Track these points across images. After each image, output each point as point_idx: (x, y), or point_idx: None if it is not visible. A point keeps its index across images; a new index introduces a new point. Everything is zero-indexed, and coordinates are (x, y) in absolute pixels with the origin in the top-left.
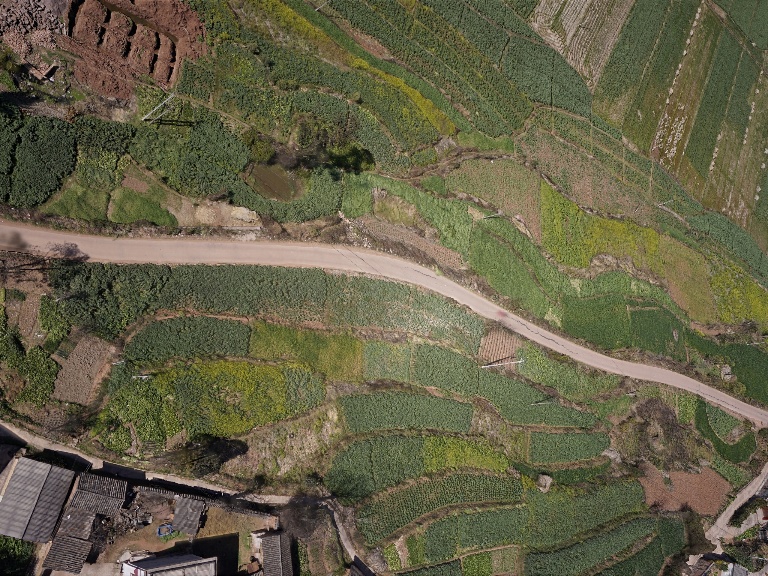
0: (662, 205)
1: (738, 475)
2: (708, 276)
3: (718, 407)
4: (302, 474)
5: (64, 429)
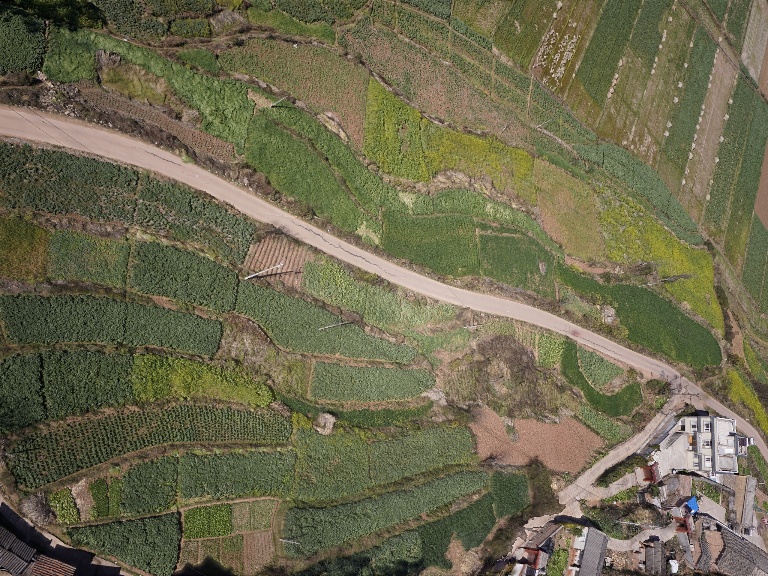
0: (542, 128)
1: (614, 429)
2: (597, 210)
3: (593, 352)
4: None
5: None
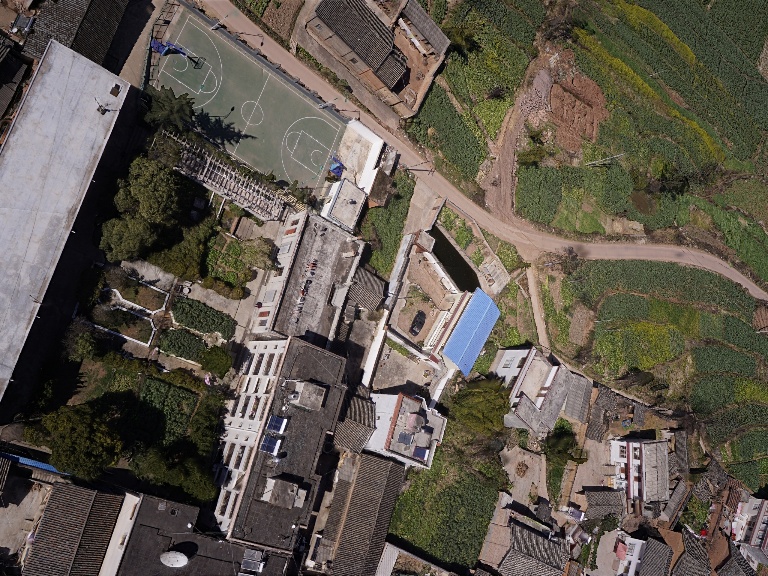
0: None
1: None
2: None
3: None
4: (677, 396)
5: (576, 360)
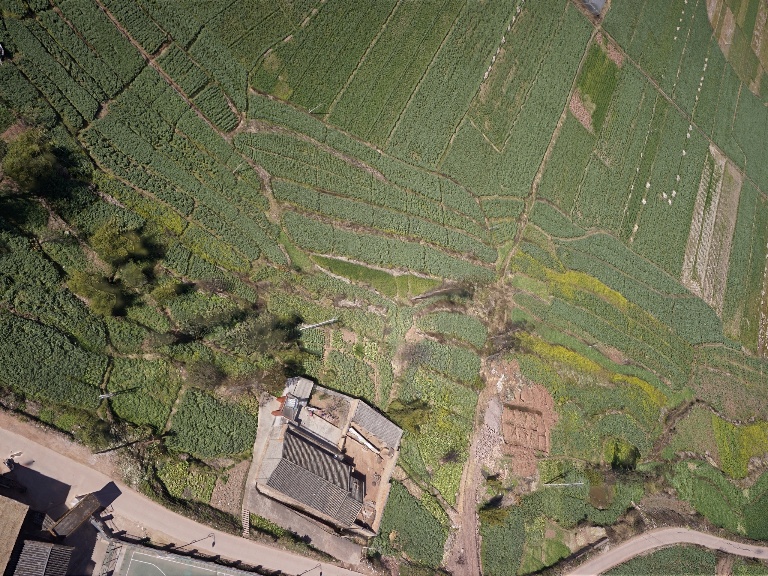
0: None
1: None
2: None
3: None
4: None
5: None
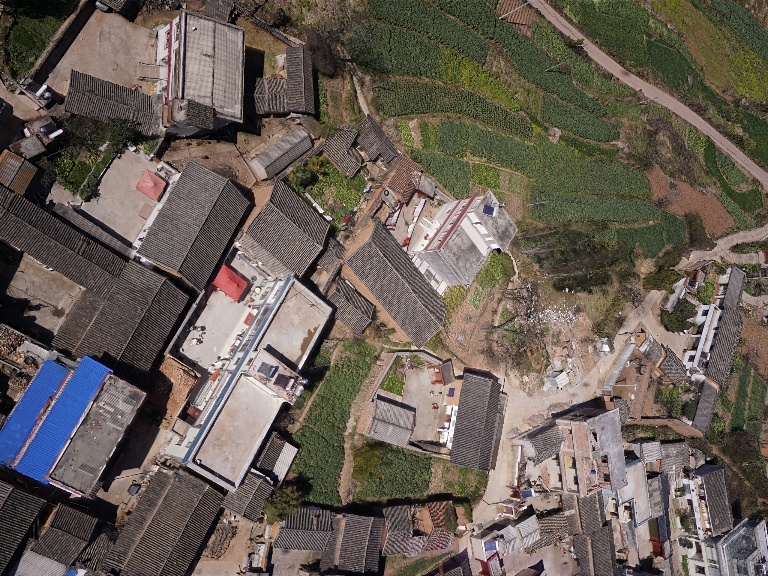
0: None
1: (743, 218)
2: (726, 53)
3: (727, 155)
4: (325, 33)
5: None
